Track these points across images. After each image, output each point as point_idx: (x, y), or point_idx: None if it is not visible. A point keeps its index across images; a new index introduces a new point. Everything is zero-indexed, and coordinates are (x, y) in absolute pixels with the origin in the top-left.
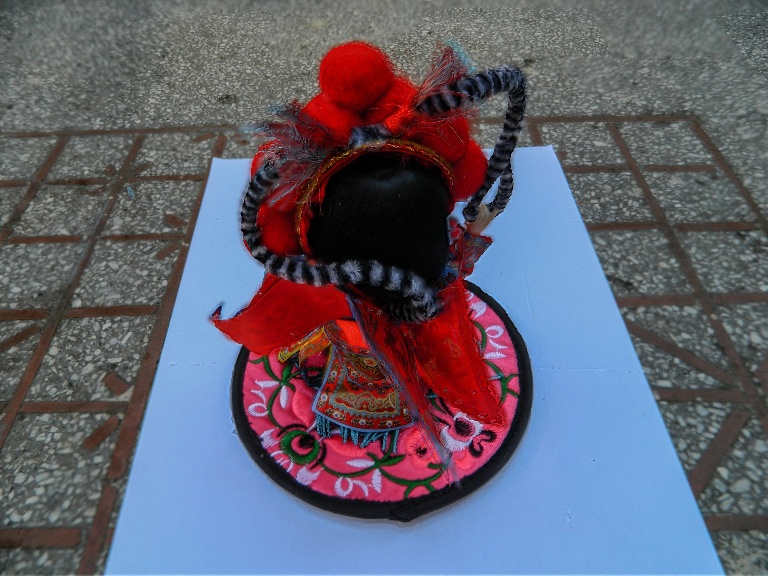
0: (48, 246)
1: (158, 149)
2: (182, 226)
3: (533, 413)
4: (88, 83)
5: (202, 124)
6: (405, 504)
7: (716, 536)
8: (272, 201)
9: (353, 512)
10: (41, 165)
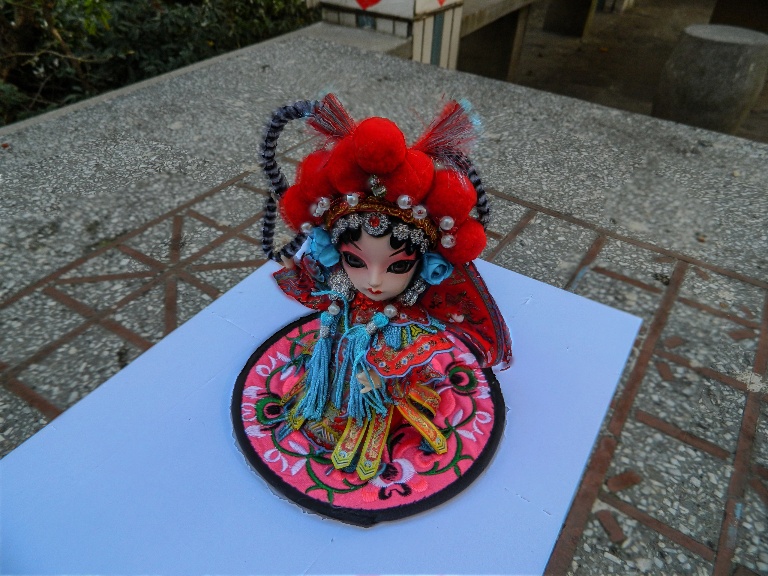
0: None
1: None
2: None
3: None
4: None
5: None
6: None
7: None
8: None
9: None
10: None
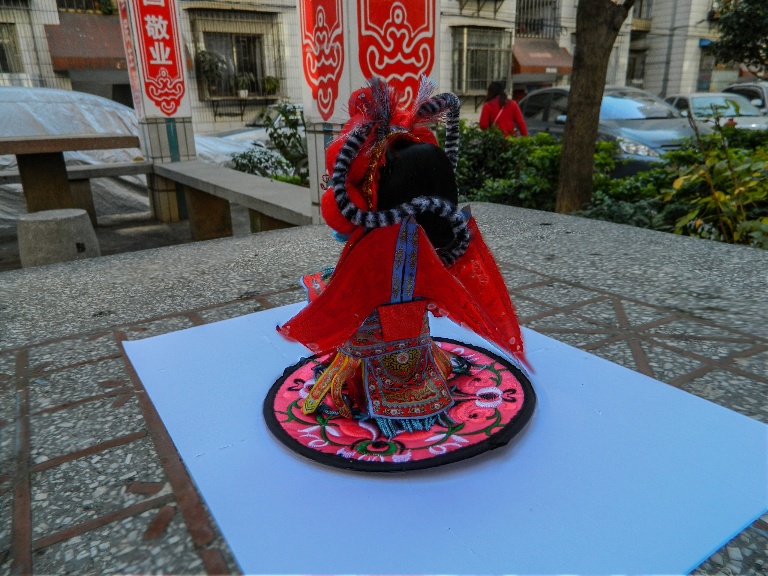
0: None
1: (51, 353)
2: (125, 383)
3: None
4: None
5: (88, 330)
6: (494, 437)
7: (682, 388)
8: (365, 153)
9: (461, 455)
10: None
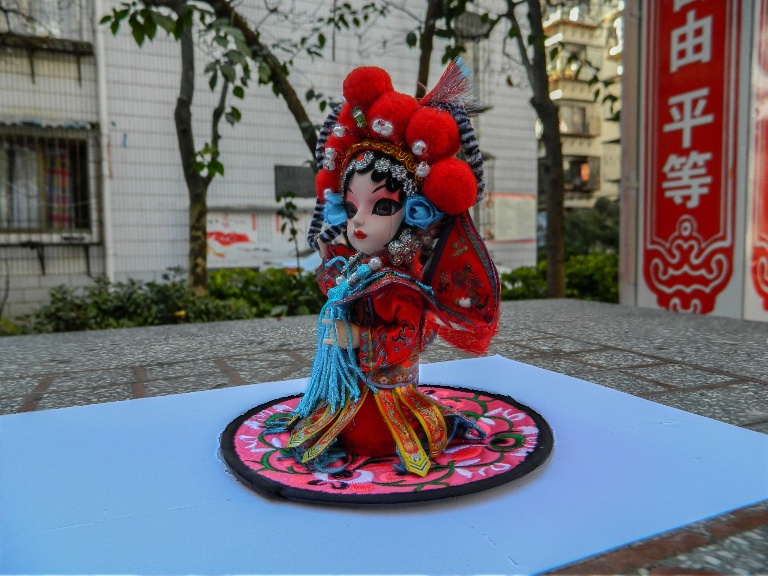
0: None
1: None
2: None
3: None
4: None
5: None
6: (499, 398)
7: None
8: None
9: None
10: None
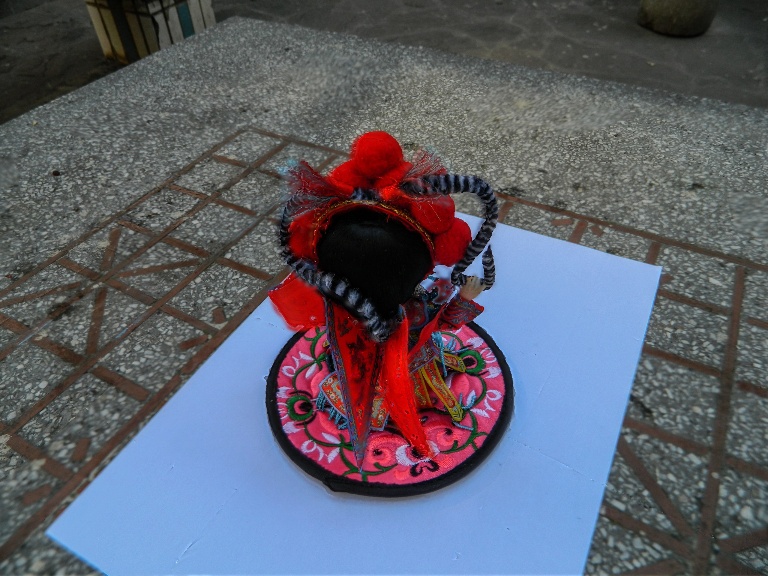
0: (234, 212)
1: None
2: None
3: (484, 470)
4: (324, 107)
5: None
6: (340, 479)
7: None
8: (292, 216)
9: (303, 465)
10: (262, 157)
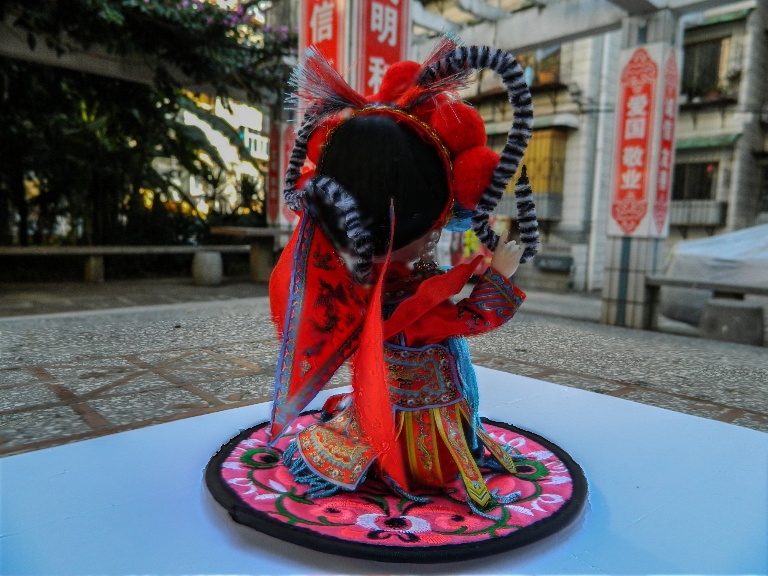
0: None
1: None
2: None
3: (501, 574)
4: None
5: (484, 352)
6: (255, 512)
7: None
8: None
9: (216, 490)
10: None
